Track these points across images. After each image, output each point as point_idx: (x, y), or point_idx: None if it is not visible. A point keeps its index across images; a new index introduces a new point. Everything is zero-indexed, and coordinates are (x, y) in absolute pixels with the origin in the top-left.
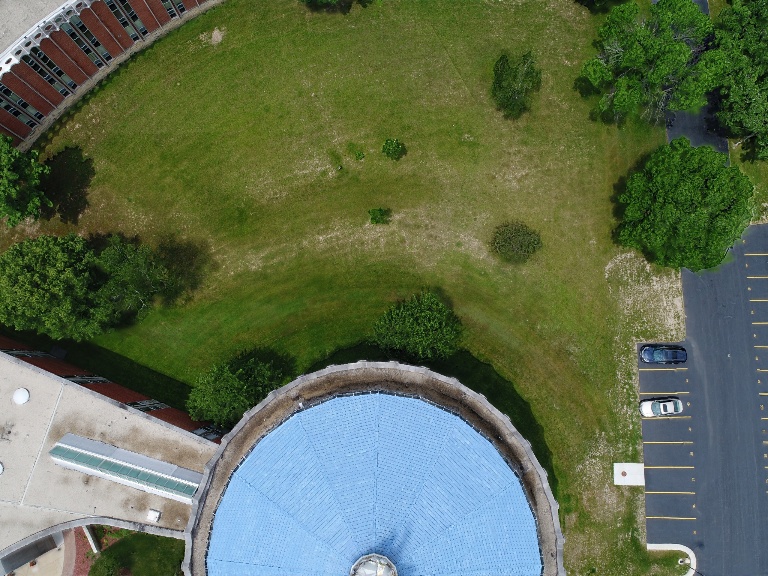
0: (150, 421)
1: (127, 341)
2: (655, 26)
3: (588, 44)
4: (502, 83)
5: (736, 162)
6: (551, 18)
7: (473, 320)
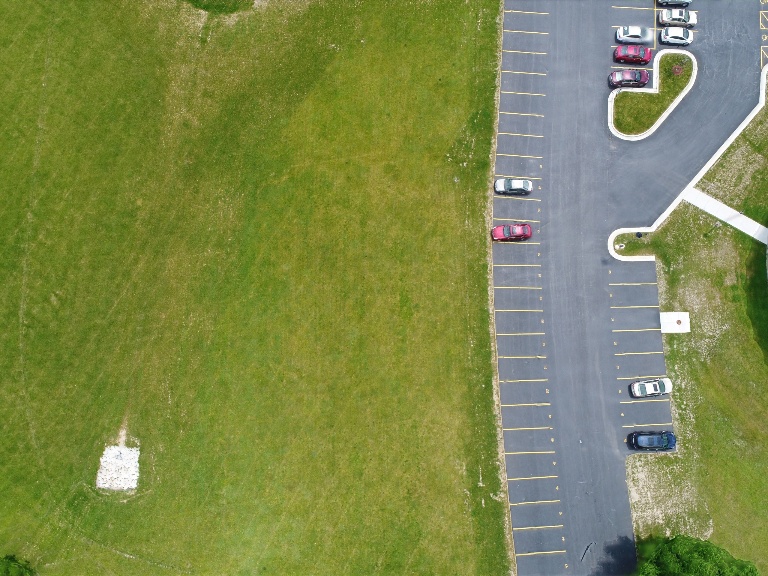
0: None
1: None
2: None
3: None
4: None
5: None
6: None
7: None
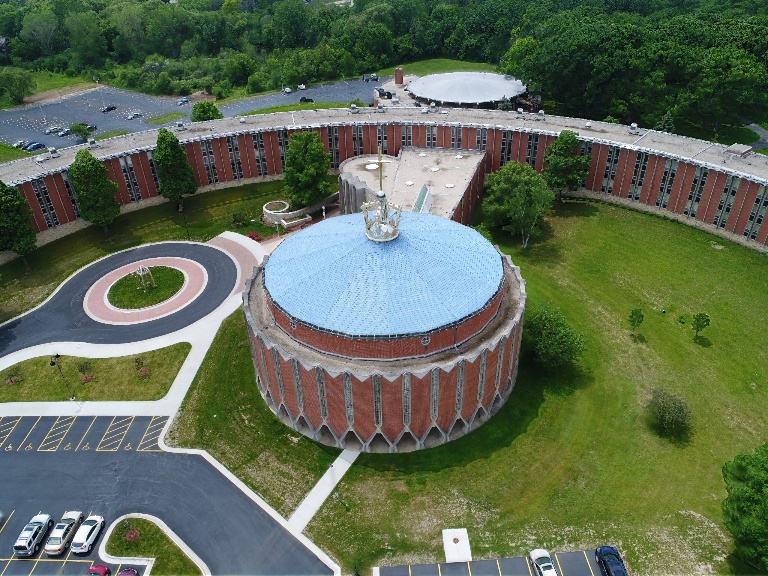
0: None
1: None
2: None
3: None
4: None
5: None
6: None
7: (576, 403)
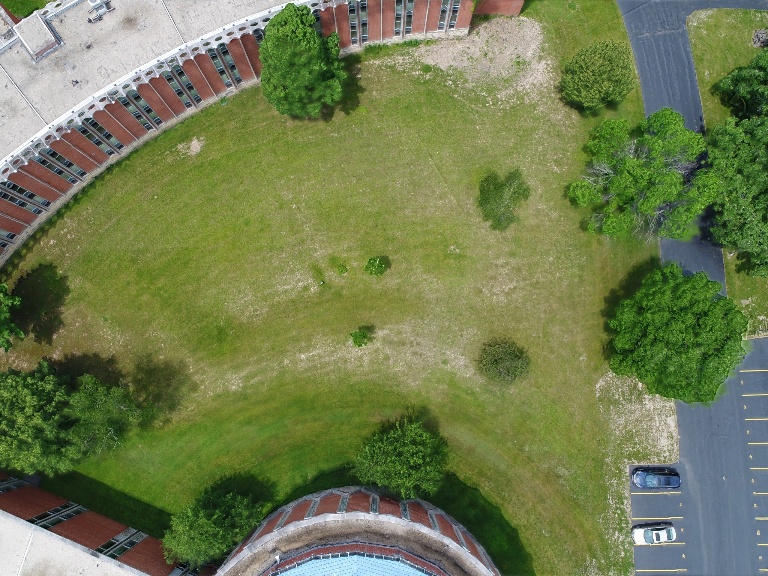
0: (123, 569)
1: (103, 465)
2: (645, 152)
3: (578, 149)
4: (488, 199)
5: (731, 273)
6: (540, 122)
7: (459, 441)
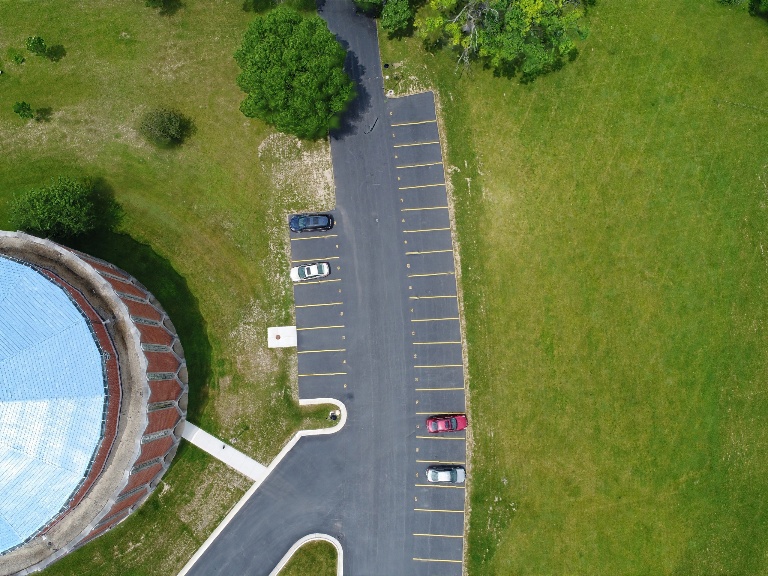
0: None
1: None
2: None
3: None
4: None
5: (384, 40)
6: None
7: (133, 206)
